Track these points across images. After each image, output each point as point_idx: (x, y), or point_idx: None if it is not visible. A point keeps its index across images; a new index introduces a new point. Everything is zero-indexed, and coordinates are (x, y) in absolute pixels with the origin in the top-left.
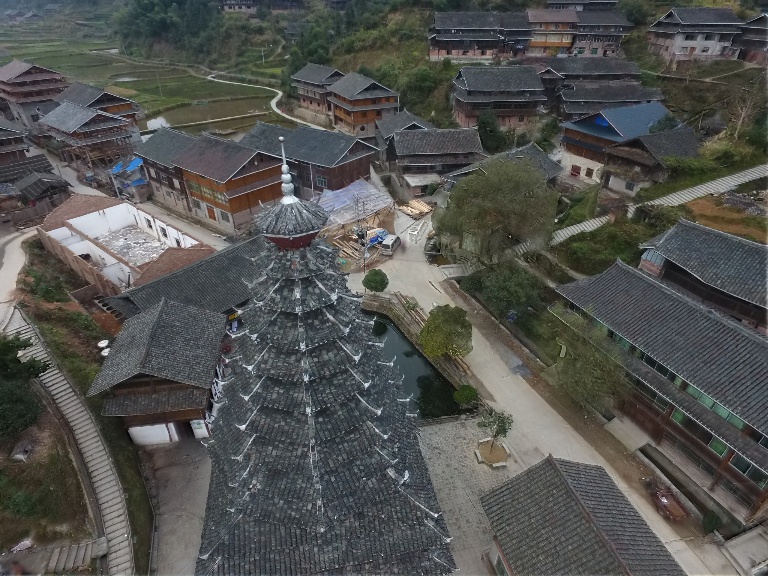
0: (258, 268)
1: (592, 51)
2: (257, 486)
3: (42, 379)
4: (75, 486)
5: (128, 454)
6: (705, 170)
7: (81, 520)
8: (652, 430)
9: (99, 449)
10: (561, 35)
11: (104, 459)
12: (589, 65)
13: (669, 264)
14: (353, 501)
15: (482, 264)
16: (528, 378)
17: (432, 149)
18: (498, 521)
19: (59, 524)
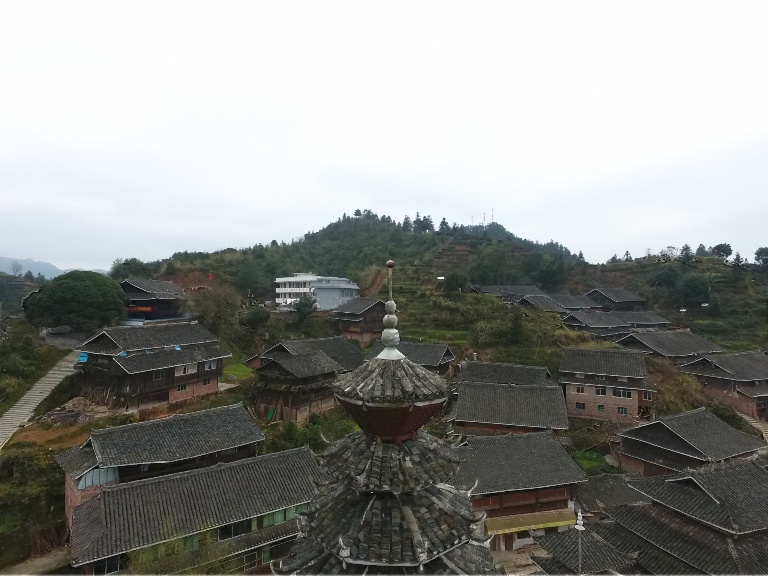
0: (439, 480)
1: None
2: None
3: None
4: None
5: None
6: None
7: None
8: None
9: None
10: None
11: None
12: None
13: (123, 471)
14: None
15: None
16: None
17: None
18: None
19: None
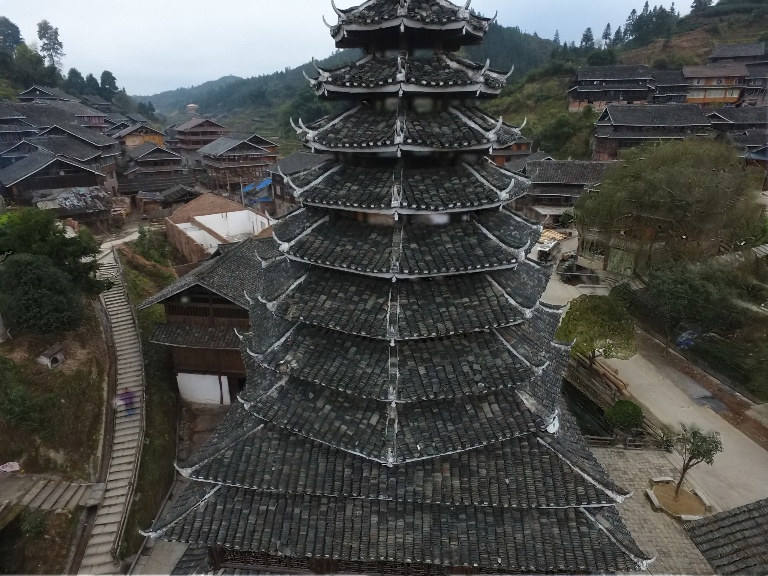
0: None
1: (767, 101)
2: (291, 363)
3: (109, 307)
4: (94, 414)
5: (167, 399)
6: None
7: (85, 454)
8: None
9: (137, 383)
10: (724, 90)
11: (138, 395)
12: (764, 114)
13: None
14: (454, 430)
15: (638, 279)
16: (725, 414)
17: (569, 179)
18: (737, 574)
19: (56, 446)
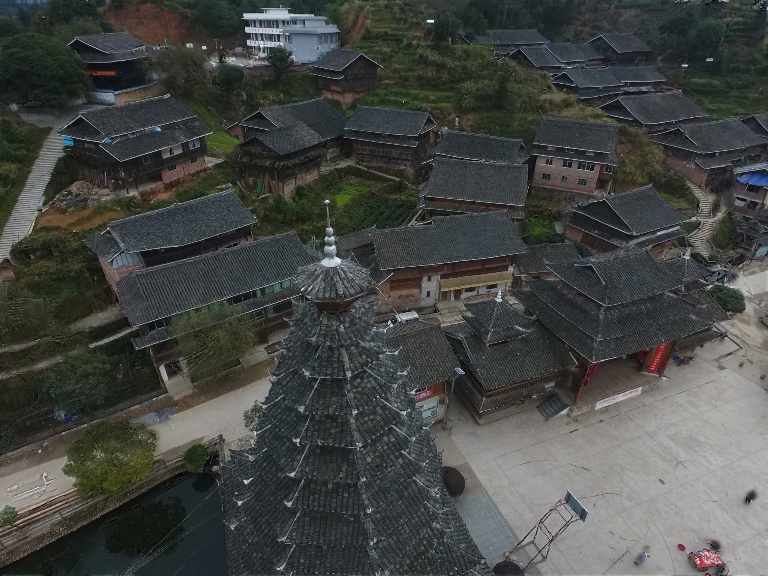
0: None
1: None
2: (436, 491)
3: None
4: None
5: None
6: (4, 196)
7: None
8: (260, 339)
9: None
10: None
11: None
12: None
13: (145, 254)
14: None
15: None
16: (177, 410)
17: None
18: None
19: None
